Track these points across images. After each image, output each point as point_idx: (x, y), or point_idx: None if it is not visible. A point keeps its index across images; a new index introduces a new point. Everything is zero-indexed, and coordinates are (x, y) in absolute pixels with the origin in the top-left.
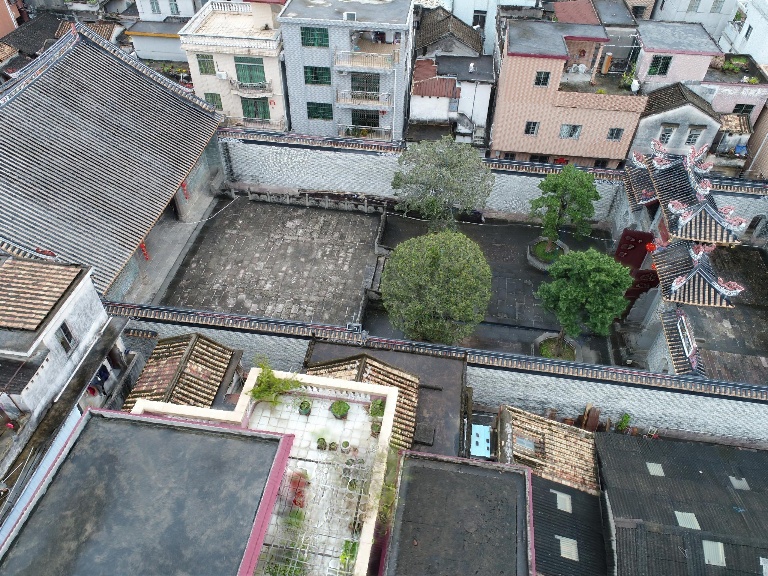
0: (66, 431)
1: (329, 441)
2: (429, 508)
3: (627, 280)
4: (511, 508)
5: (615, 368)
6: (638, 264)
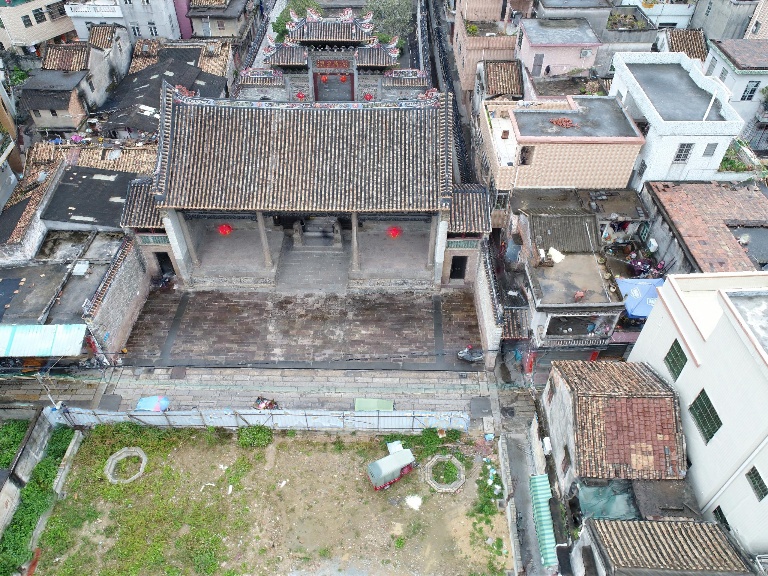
0: None
1: None
2: None
3: None
4: None
5: (246, 61)
6: None
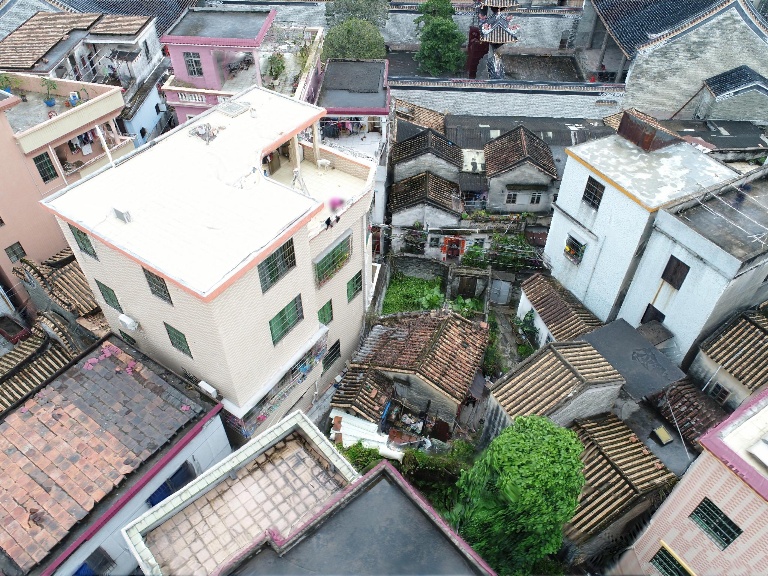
0: (153, 95)
1: None
2: (341, 71)
3: (463, 37)
4: (378, 69)
5: (455, 79)
6: (483, 53)
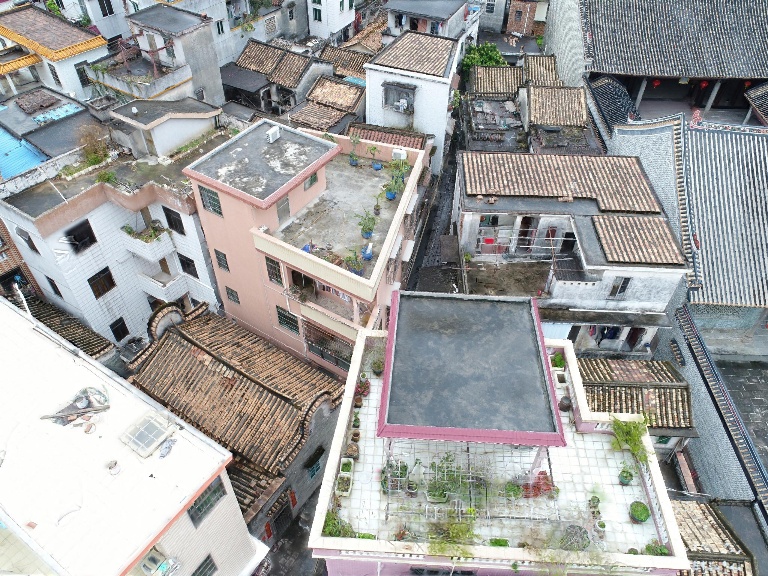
0: (551, 328)
1: (601, 510)
2: None
3: None
4: None
5: None
6: None
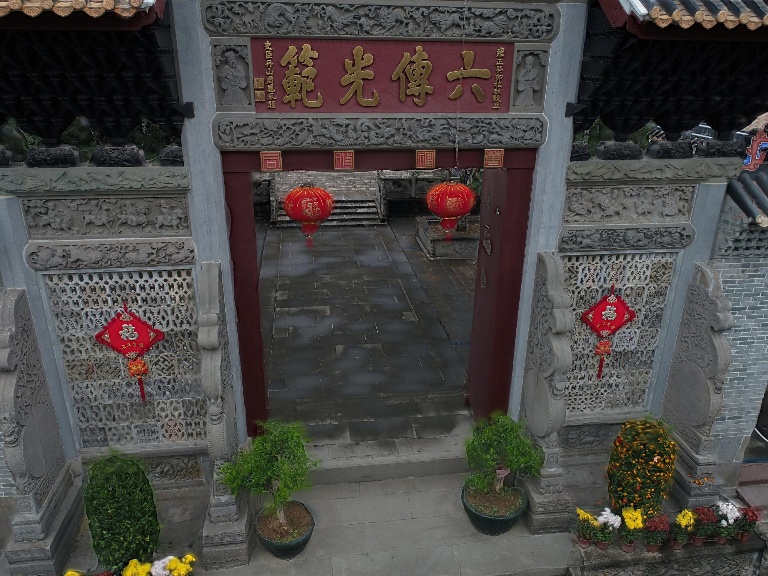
0: None
1: None
2: None
3: None
4: None
5: None
6: None
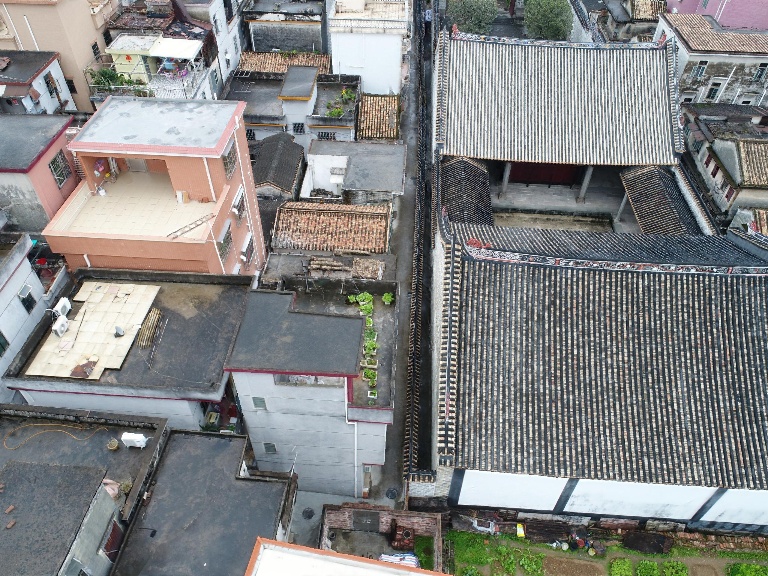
0: None
1: None
2: None
3: None
4: None
5: None
6: None
